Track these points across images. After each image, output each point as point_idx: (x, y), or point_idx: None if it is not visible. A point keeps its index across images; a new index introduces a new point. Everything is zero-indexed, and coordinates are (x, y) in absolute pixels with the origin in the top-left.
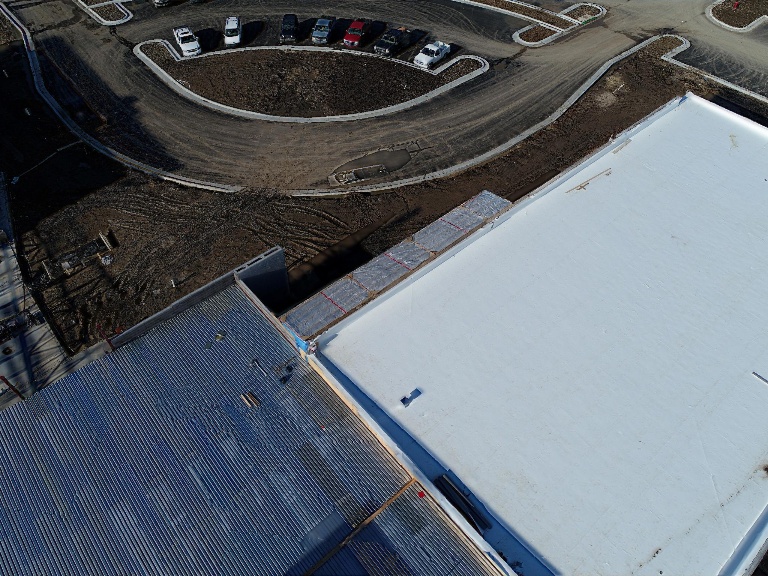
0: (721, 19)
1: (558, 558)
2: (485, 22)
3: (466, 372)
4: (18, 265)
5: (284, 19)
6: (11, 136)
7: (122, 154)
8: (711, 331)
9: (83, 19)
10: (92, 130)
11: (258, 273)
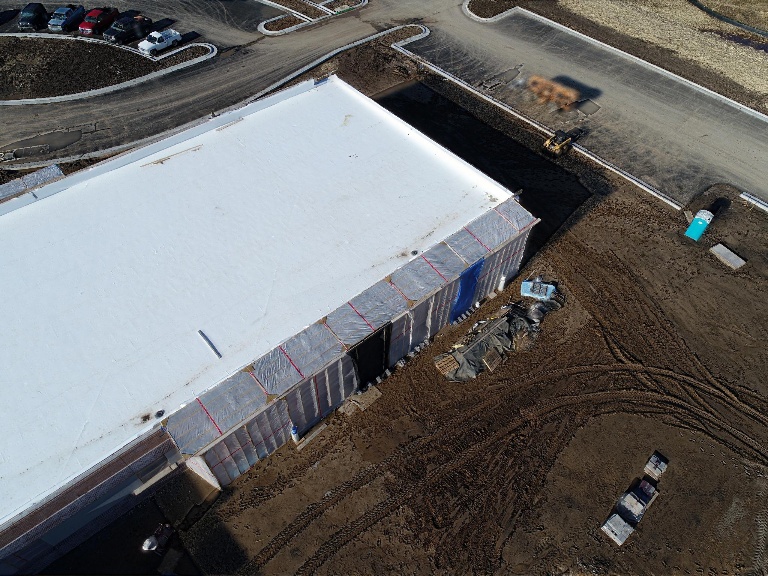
0: (473, 10)
1: None
2: (240, 12)
3: None
4: None
5: (25, 7)
6: None
7: None
8: (187, 293)
9: None
10: None
11: None
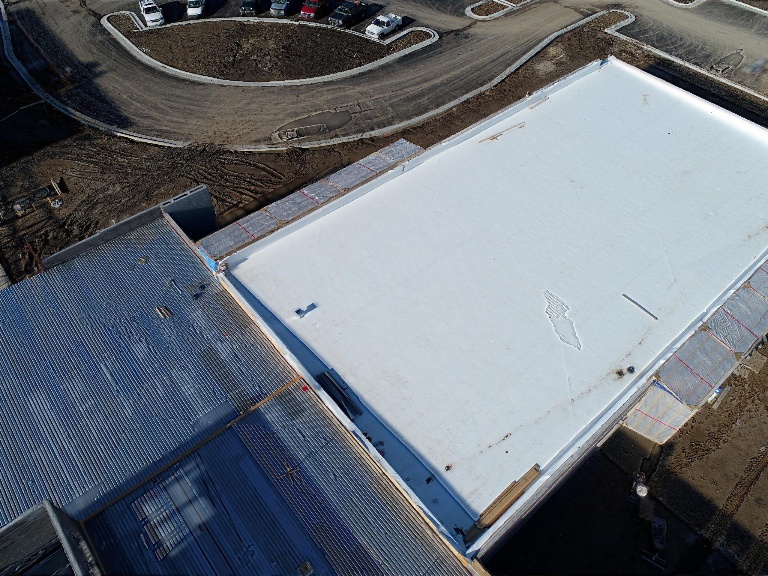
0: None
1: (417, 439)
2: None
3: (360, 290)
4: None
5: None
6: None
7: (80, 113)
8: (591, 260)
9: None
10: (54, 92)
11: (185, 208)
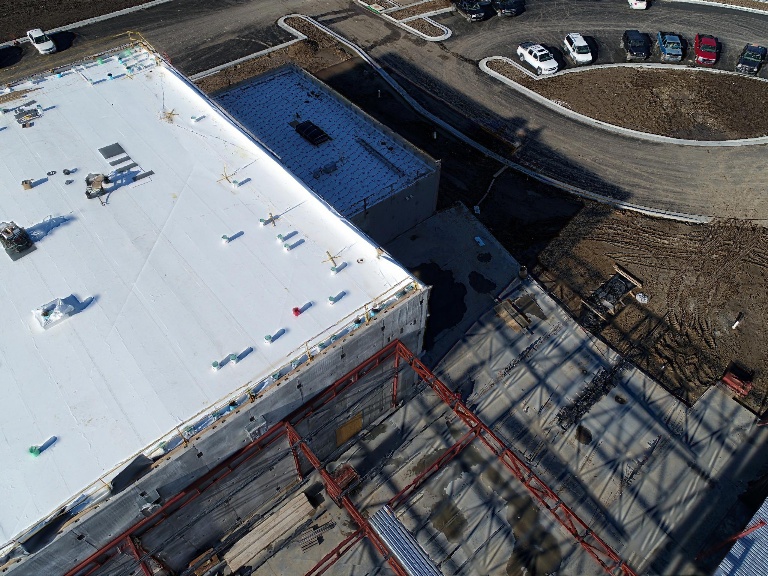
0: None
1: None
2: None
3: None
4: (557, 304)
5: (630, 35)
6: None
7: (558, 181)
8: None
9: (403, 34)
10: (507, 154)
11: None
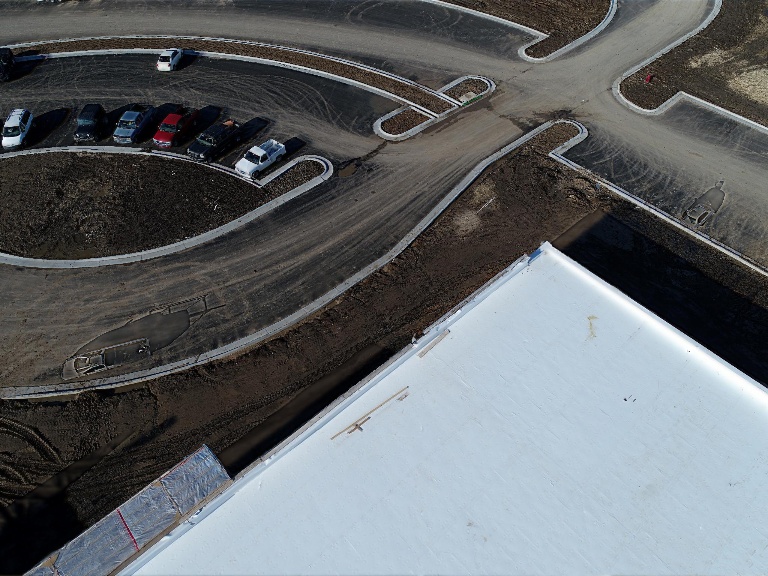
0: (629, 97)
1: None
2: (345, 105)
3: None
4: None
5: (82, 112)
6: None
7: None
8: None
9: None
10: None
11: None
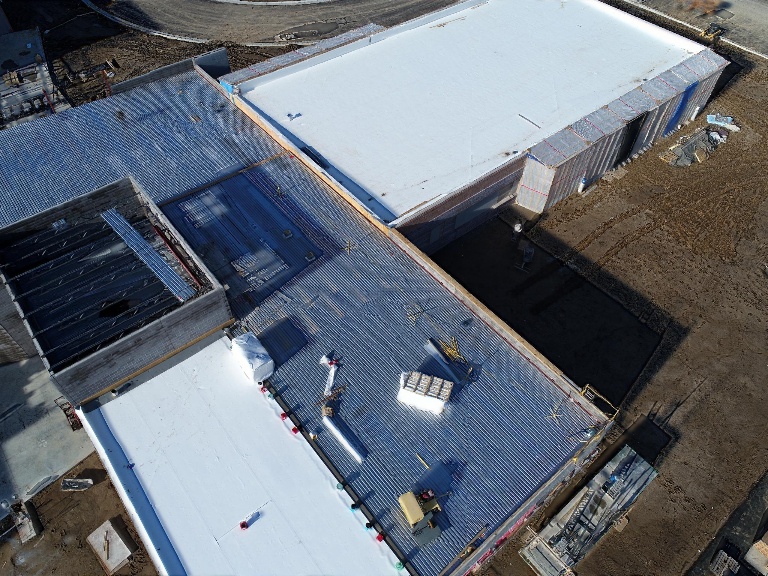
0: None
1: (365, 181)
2: None
3: (333, 107)
4: (49, 75)
5: None
6: (44, 7)
7: (125, 20)
8: (500, 96)
9: None
10: (103, 6)
11: (209, 64)
